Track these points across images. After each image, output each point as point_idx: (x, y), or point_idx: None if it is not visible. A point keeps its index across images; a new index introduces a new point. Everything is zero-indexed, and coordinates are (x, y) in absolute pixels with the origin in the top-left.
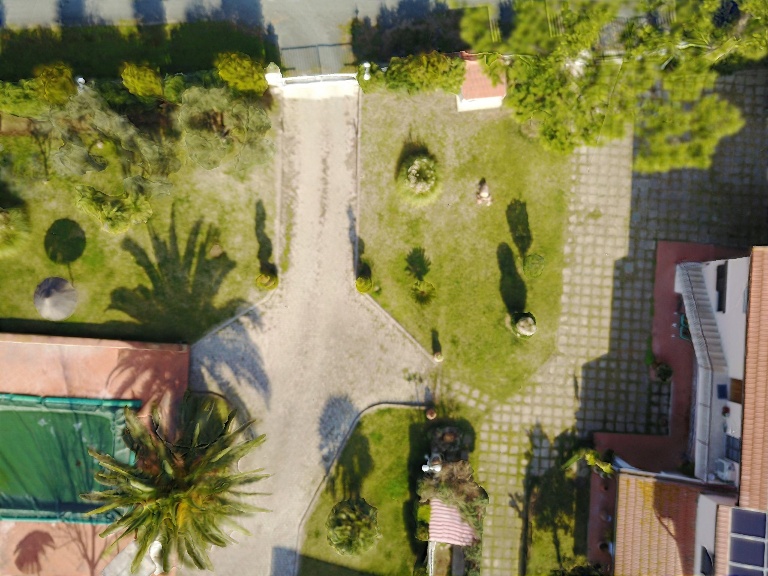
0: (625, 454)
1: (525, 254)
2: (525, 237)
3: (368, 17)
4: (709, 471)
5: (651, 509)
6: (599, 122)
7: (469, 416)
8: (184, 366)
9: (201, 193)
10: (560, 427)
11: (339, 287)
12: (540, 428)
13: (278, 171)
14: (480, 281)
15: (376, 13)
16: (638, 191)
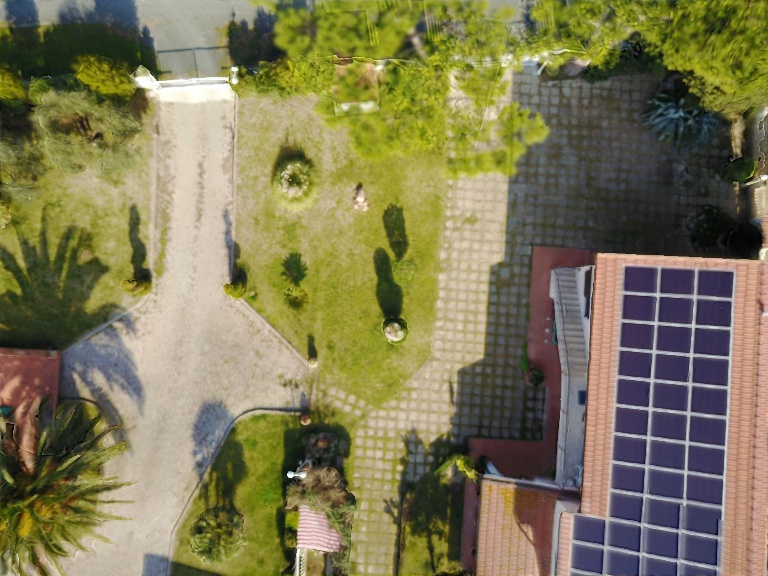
0: (498, 459)
1: (401, 259)
2: (402, 242)
3: (245, 20)
4: (568, 477)
5: (511, 515)
6: (476, 127)
7: (345, 422)
8: (54, 372)
9: (73, 197)
10: (435, 432)
11: (215, 292)
12: (415, 433)
13: (153, 175)
14: (356, 286)
15: (253, 16)
16: (515, 196)
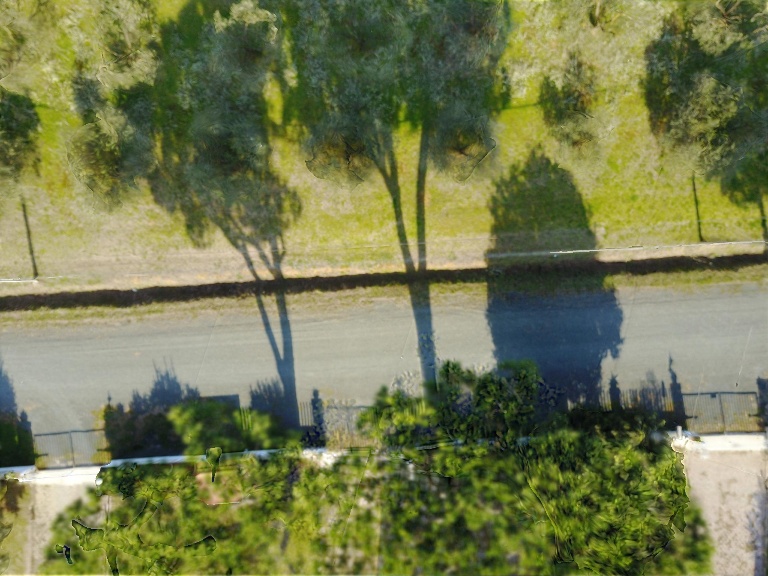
0: None
1: None
2: None
3: (120, 404)
4: None
5: None
6: (346, 513)
7: None
8: None
9: None
10: None
11: None
12: None
13: (27, 560)
14: None
15: (128, 400)
16: None
